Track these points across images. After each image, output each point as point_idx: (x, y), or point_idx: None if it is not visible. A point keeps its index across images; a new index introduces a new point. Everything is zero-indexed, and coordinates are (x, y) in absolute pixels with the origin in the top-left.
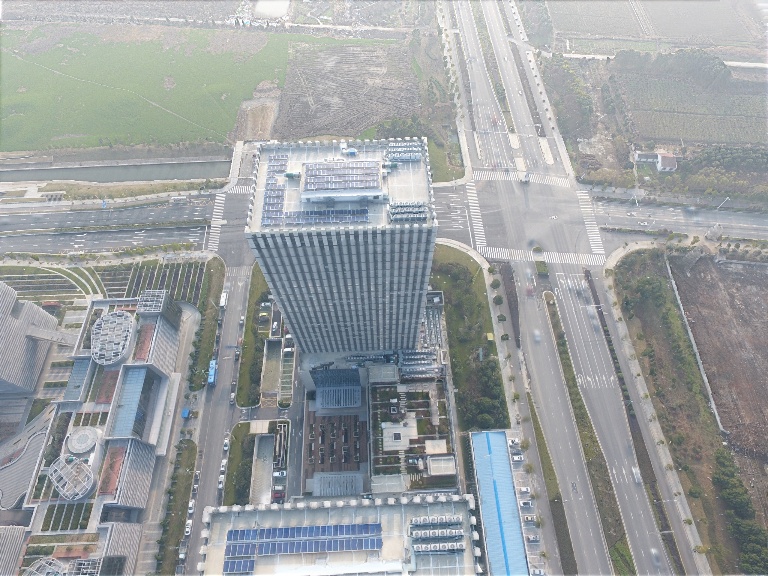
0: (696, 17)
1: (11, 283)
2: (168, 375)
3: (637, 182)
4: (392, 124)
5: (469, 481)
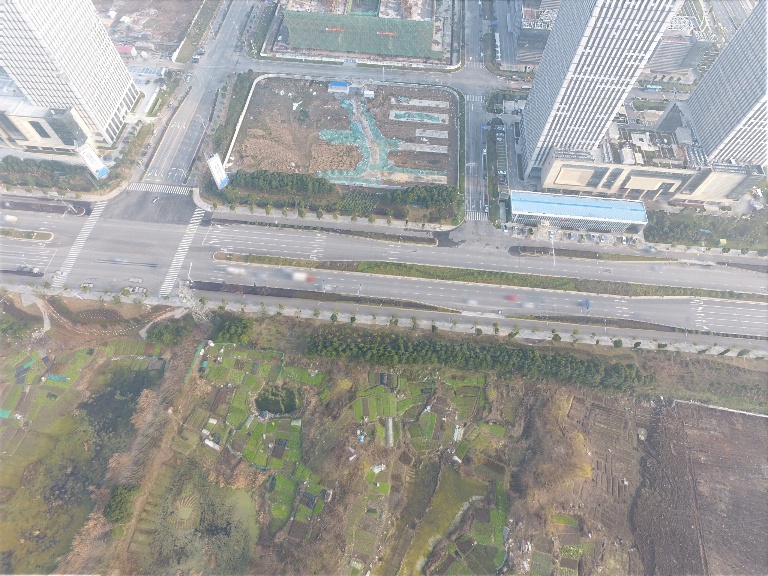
0: None
1: (689, 6)
2: None
3: None
4: None
5: None
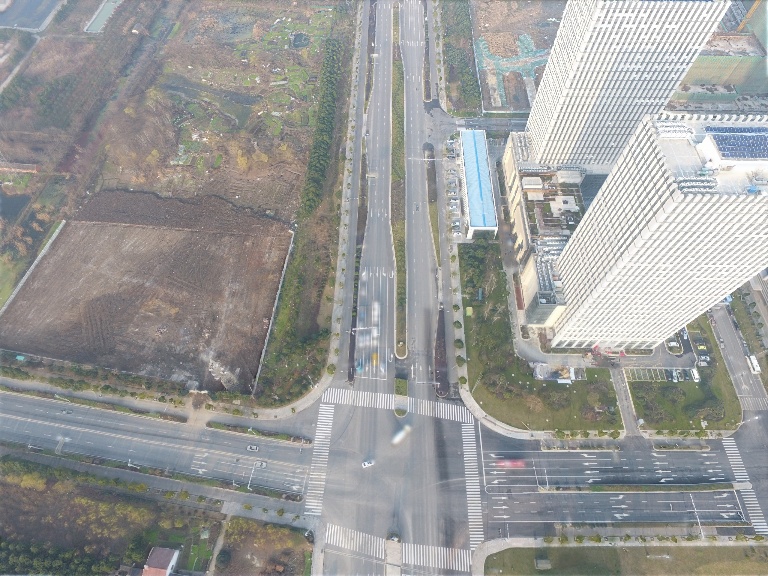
0: None
1: None
2: (766, 279)
3: (223, 529)
4: None
5: None
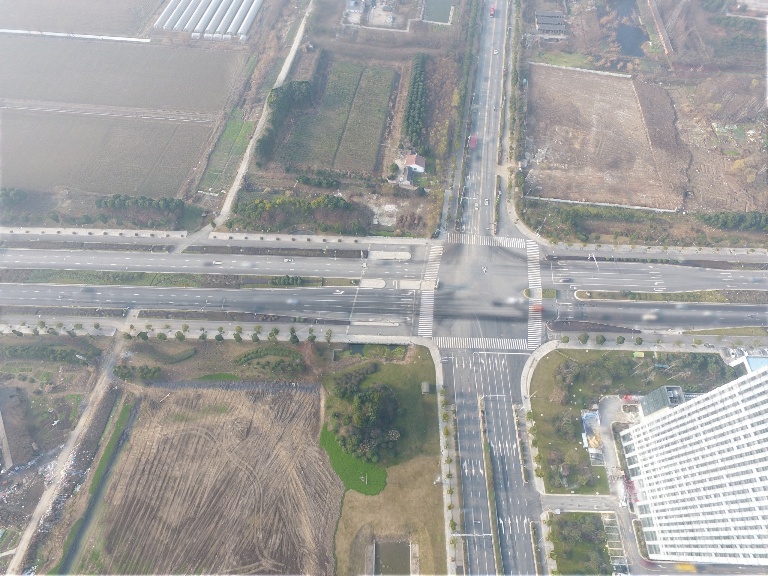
0: (197, 77)
1: None
2: None
3: None
4: (362, 425)
5: None
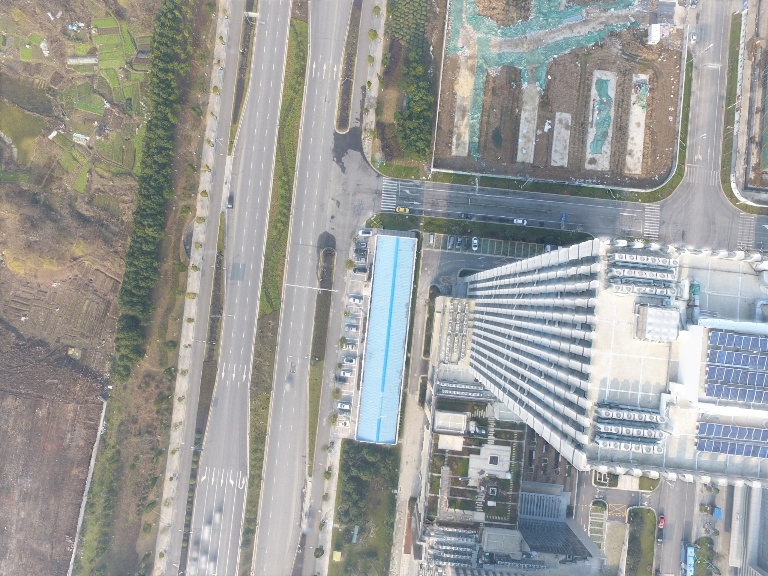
0: None
1: None
2: (750, 568)
3: None
4: None
5: (405, 392)
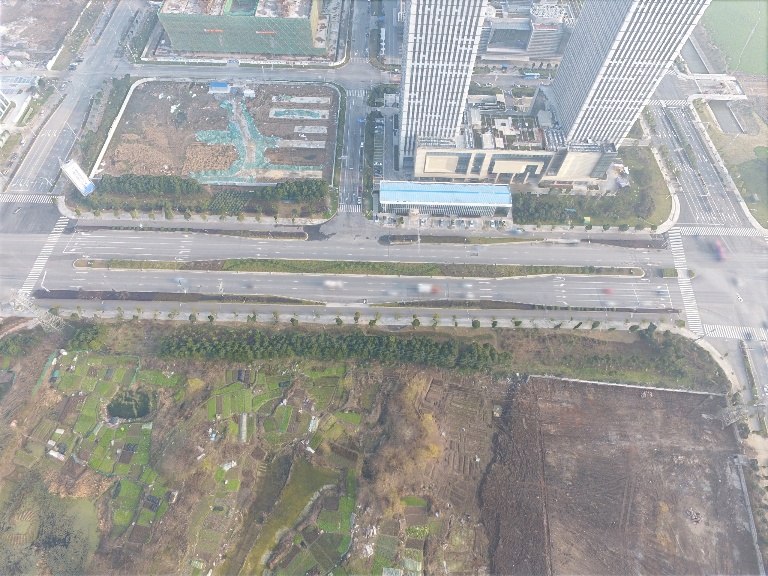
0: None
1: None
2: None
3: None
4: None
5: None
